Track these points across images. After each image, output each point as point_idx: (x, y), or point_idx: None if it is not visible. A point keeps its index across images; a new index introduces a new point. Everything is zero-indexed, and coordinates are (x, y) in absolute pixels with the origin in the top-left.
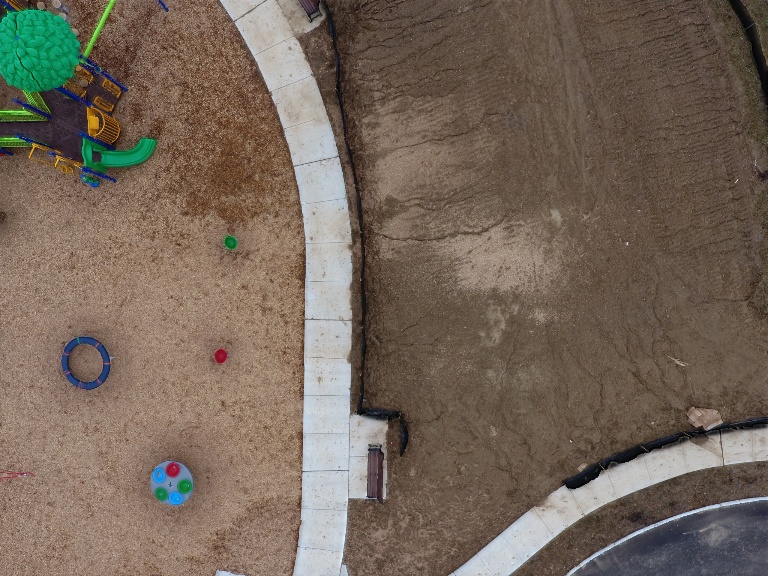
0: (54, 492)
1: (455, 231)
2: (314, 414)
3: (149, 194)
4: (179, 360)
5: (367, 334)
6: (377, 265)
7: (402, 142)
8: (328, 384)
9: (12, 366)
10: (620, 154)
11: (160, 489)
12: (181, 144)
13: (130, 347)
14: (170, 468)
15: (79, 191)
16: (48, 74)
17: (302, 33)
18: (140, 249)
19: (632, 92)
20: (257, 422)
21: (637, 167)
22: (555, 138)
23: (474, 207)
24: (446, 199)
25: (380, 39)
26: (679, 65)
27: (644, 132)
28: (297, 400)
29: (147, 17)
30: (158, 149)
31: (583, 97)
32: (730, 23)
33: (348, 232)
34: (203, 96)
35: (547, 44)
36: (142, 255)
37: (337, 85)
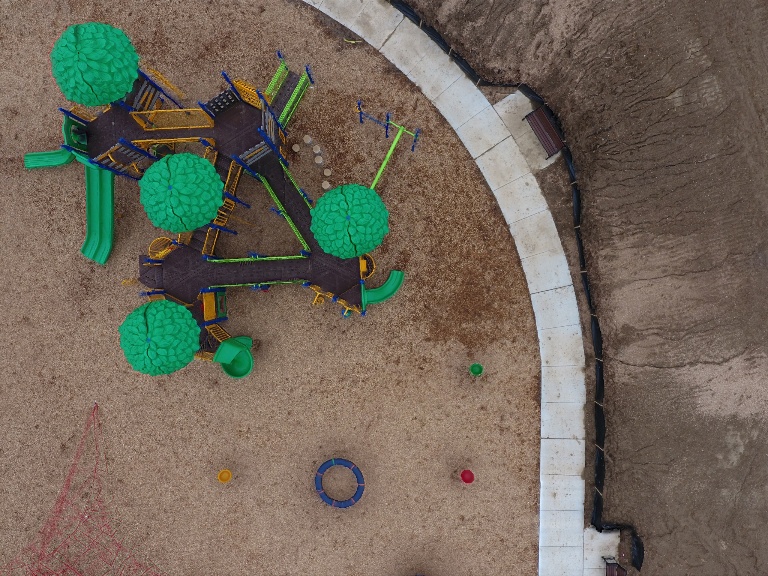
0: None
1: (695, 360)
2: (550, 528)
3: (395, 322)
4: (422, 477)
5: None
6: (611, 388)
7: (641, 275)
8: (563, 499)
9: (267, 484)
10: None
11: None
12: (425, 275)
13: (377, 466)
14: None
15: (329, 319)
16: (367, 245)
17: (538, 169)
18: (386, 373)
19: None
20: (495, 535)
21: None
22: None
23: (715, 339)
24: (686, 330)
25: (619, 179)
26: None
27: None
28: (533, 514)
29: (393, 156)
30: (404, 280)
31: None
32: None
33: (582, 356)
34: (445, 229)
35: None
36: (387, 379)
37: (579, 222)
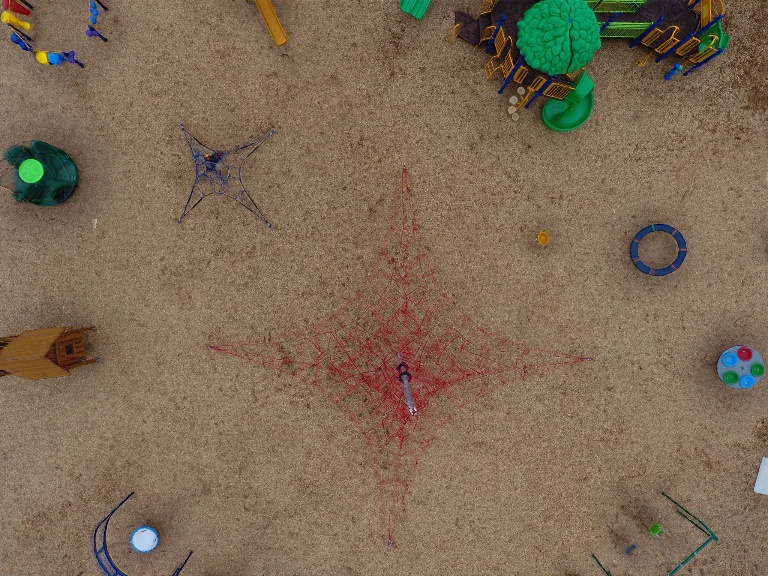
0: (614, 377)
1: None
2: None
3: (713, 88)
4: (737, 250)
5: None
6: None
7: None
8: None
9: (578, 254)
10: None
11: (732, 373)
12: (746, 40)
13: (691, 237)
14: (741, 352)
15: (646, 85)
16: None
17: None
18: (702, 142)
19: None
20: None
21: None
22: None
23: None
24: None
25: None
26: None
27: None
28: None
29: None
30: None
31: None
32: None
33: None
34: None
35: None
36: (703, 148)
37: None
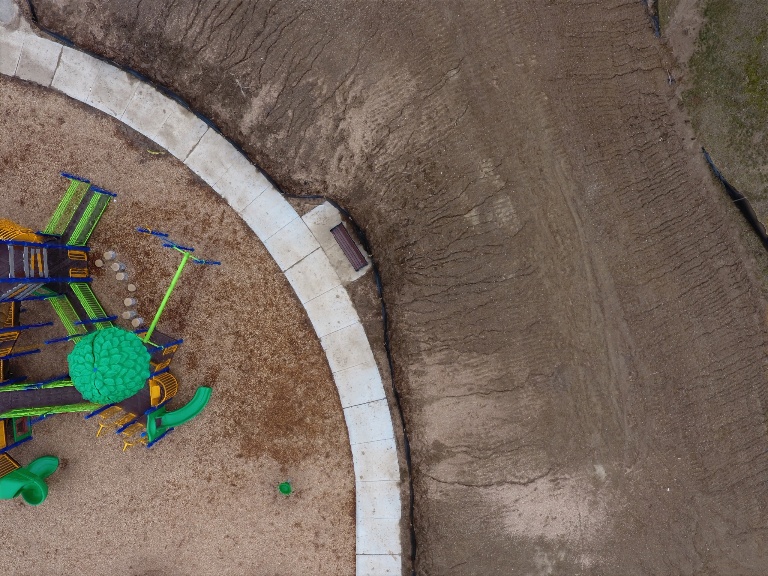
0: None
1: (502, 480)
2: None
3: (205, 438)
4: None
5: (416, 568)
6: (425, 504)
7: (448, 392)
8: None
9: None
10: (660, 409)
11: None
12: (235, 390)
13: None
14: None
15: (138, 437)
16: (122, 393)
17: (349, 281)
18: (197, 490)
19: (670, 347)
20: None
21: (677, 419)
22: (598, 399)
23: (520, 459)
24: (492, 449)
25: (425, 294)
26: (714, 310)
27: (683, 384)
28: None
29: (200, 269)
30: (213, 396)
31: (624, 359)
32: (761, 259)
33: (396, 470)
34: (255, 343)
35: (589, 311)
36: (199, 496)
37: None
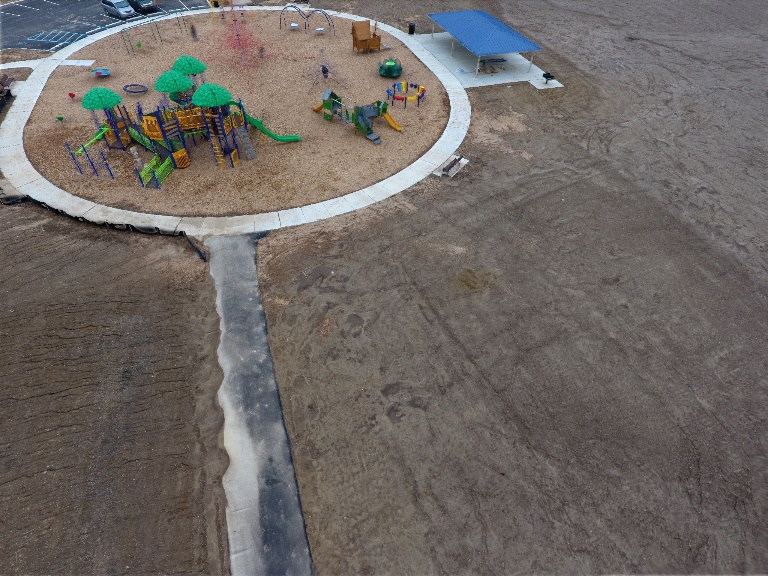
0: None
1: None
2: (35, 93)
3: None
4: None
5: None
6: None
7: None
8: None
9: None
10: None
11: (105, 70)
12: None
13: None
14: None
15: None
16: None
17: (2, 180)
18: None
19: None
20: (64, 90)
21: None
22: None
23: None
24: None
25: None
26: None
27: None
28: None
29: None
30: None
31: None
32: None
33: None
34: None
35: None
36: None
37: None
